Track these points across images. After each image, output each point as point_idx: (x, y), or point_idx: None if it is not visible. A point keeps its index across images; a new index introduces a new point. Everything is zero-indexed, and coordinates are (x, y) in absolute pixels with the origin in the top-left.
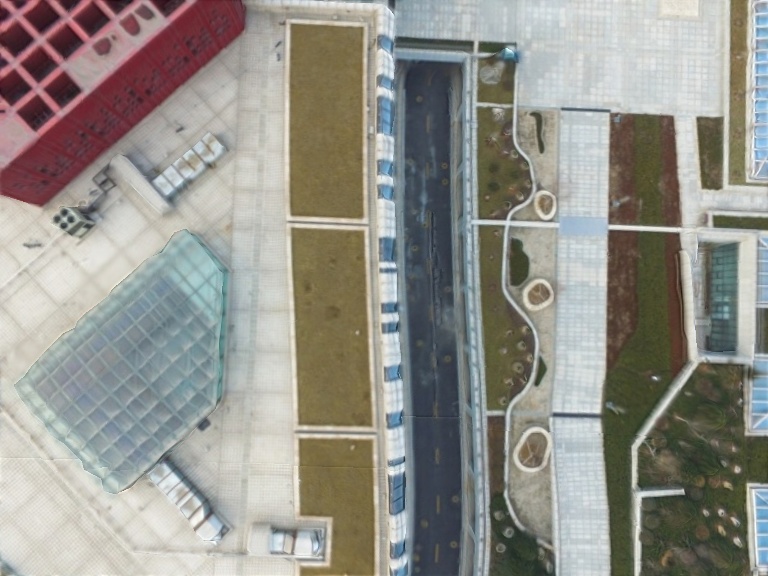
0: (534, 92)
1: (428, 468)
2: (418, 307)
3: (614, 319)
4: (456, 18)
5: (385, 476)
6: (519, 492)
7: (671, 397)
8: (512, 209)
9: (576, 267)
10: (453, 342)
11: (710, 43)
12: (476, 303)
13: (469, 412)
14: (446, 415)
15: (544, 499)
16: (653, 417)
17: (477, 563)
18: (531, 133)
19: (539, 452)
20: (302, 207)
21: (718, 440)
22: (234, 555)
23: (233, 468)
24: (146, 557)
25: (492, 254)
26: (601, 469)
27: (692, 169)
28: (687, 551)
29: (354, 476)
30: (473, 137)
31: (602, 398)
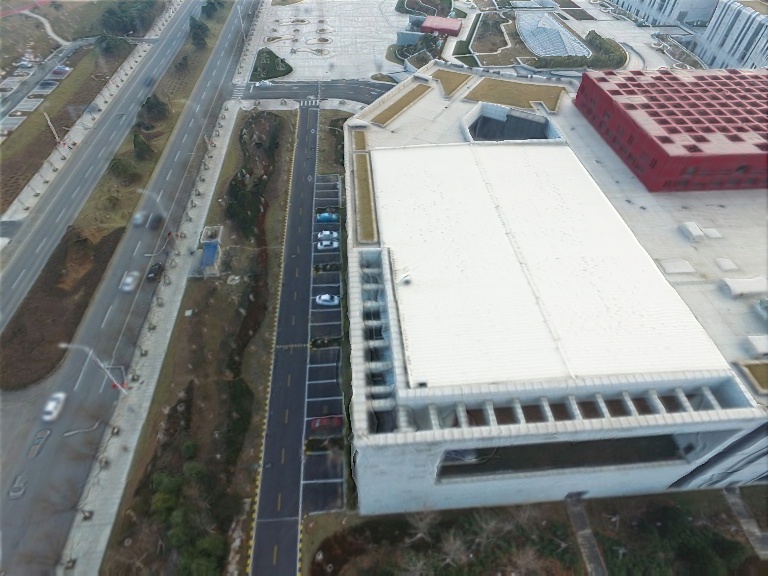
0: None
1: None
2: None
3: None
4: None
5: None
6: None
7: None
8: None
9: (587, 5)
10: None
11: None
12: None
13: None
14: None
15: None
16: None
17: None
18: None
19: None
20: None
21: None
22: None
23: None
24: None
25: None
26: None
27: None
28: None
29: None
30: None
31: None
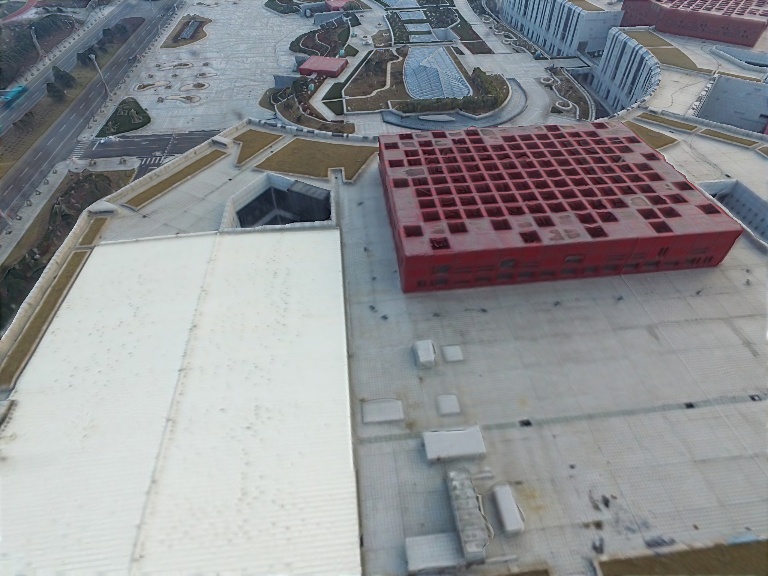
0: None
1: None
2: None
3: None
4: None
5: None
6: None
7: (453, 24)
8: None
9: None
10: None
11: None
12: None
13: None
14: None
15: None
16: None
17: None
18: None
19: None
20: (582, 0)
21: None
22: None
23: None
24: None
25: None
26: None
27: None
28: None
29: None
30: None
31: None
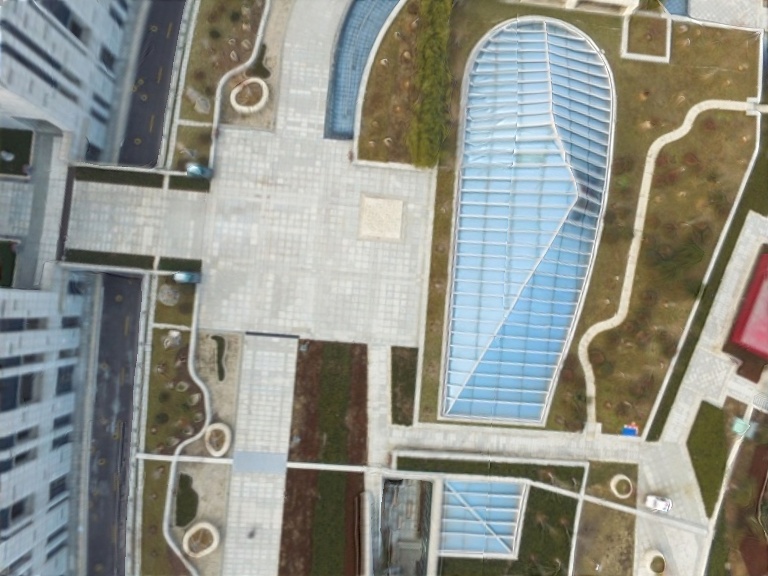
0: (217, 314)
1: None
2: (100, 528)
3: (287, 565)
4: (137, 230)
5: None
6: None
7: None
8: (181, 443)
9: (249, 507)
10: None
11: (411, 267)
12: (136, 545)
13: None
14: None
15: None
16: None
17: None
18: (212, 358)
19: None
20: None
21: None
22: None
23: None
24: None
25: (155, 492)
26: None
27: (383, 402)
28: None
29: None
30: (146, 361)
31: None
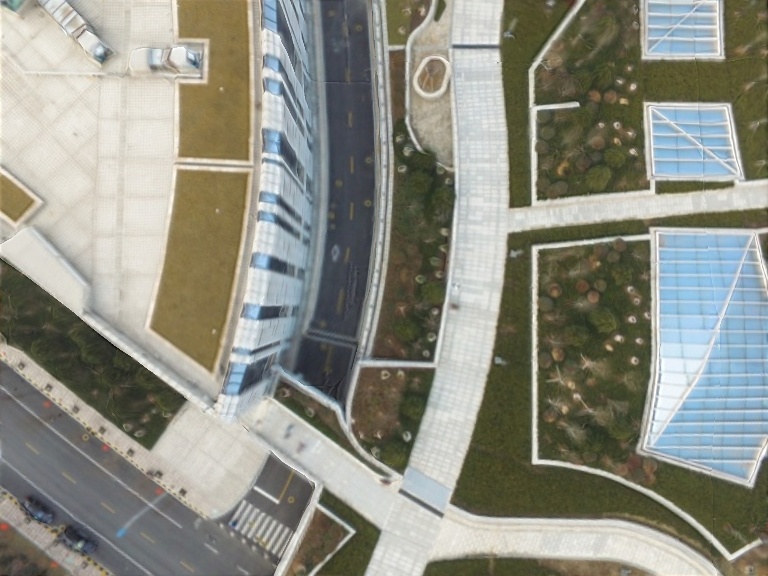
0: None
1: (342, 131)
2: None
3: None
4: None
5: (259, 1)
6: (421, 123)
7: (566, 21)
8: None
9: None
10: (364, 12)
11: None
12: None
13: None
14: (358, 80)
15: (446, 128)
16: (549, 41)
17: (381, 188)
18: None
19: (438, 77)
20: None
21: (614, 61)
22: (118, 78)
23: (117, 0)
24: (37, 82)
25: None
26: (500, 95)
27: None
28: (581, 156)
29: (229, 1)
30: None
31: (500, 29)
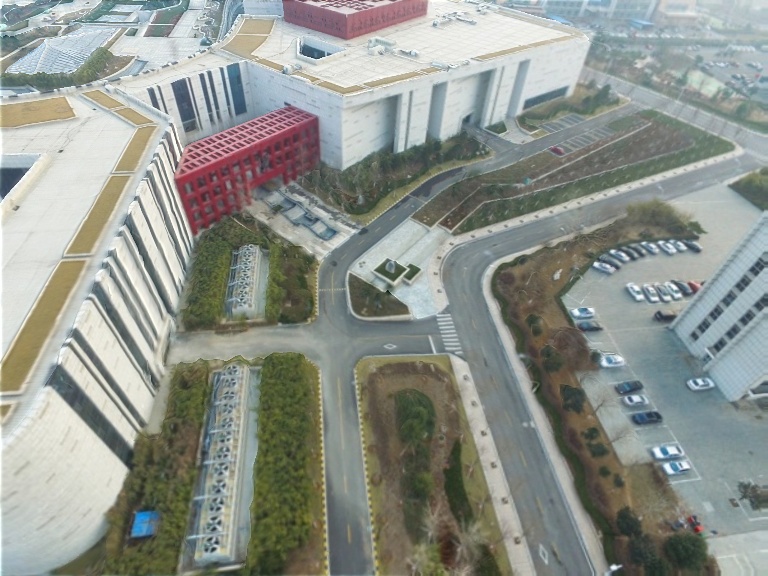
0: None
1: None
2: None
3: None
4: None
5: None
6: None
7: (165, 8)
8: None
9: None
10: None
11: None
12: None
13: (228, 18)
14: None
15: None
16: (172, 7)
17: None
18: (198, 36)
19: None
20: None
21: None
22: None
23: None
24: None
25: None
26: None
27: None
28: None
29: None
30: None
31: None
